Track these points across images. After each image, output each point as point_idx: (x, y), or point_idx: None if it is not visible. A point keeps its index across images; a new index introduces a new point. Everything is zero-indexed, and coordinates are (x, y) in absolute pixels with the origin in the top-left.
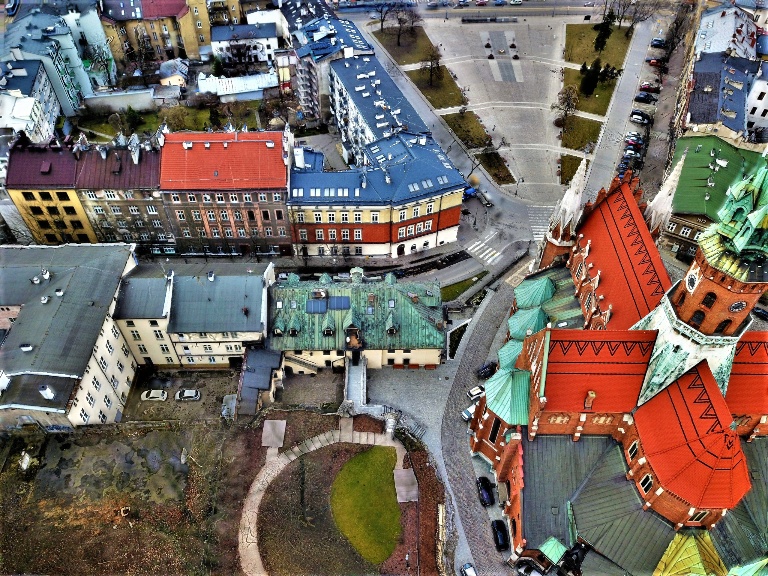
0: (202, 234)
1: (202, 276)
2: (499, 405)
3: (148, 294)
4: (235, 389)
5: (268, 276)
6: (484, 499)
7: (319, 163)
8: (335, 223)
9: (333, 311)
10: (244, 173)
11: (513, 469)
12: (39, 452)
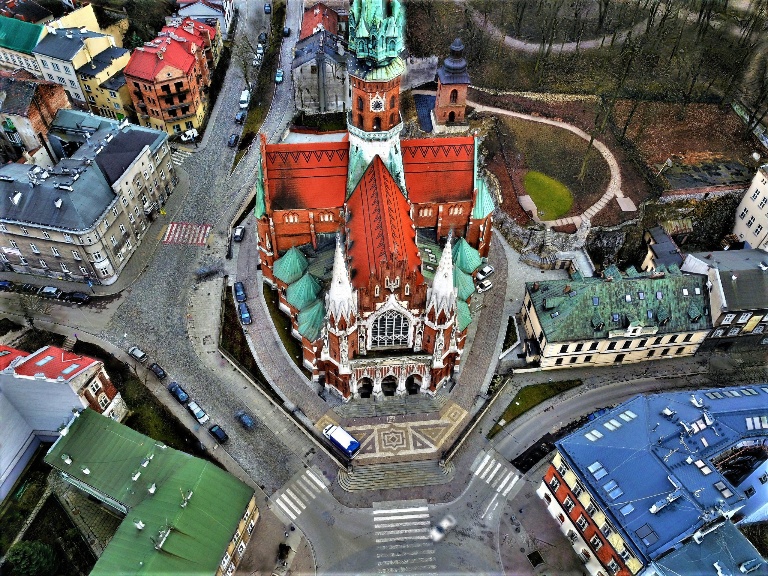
0: None
1: None
2: None
3: None
4: None
5: None
6: None
7: None
8: None
9: None
10: None
11: None
12: None
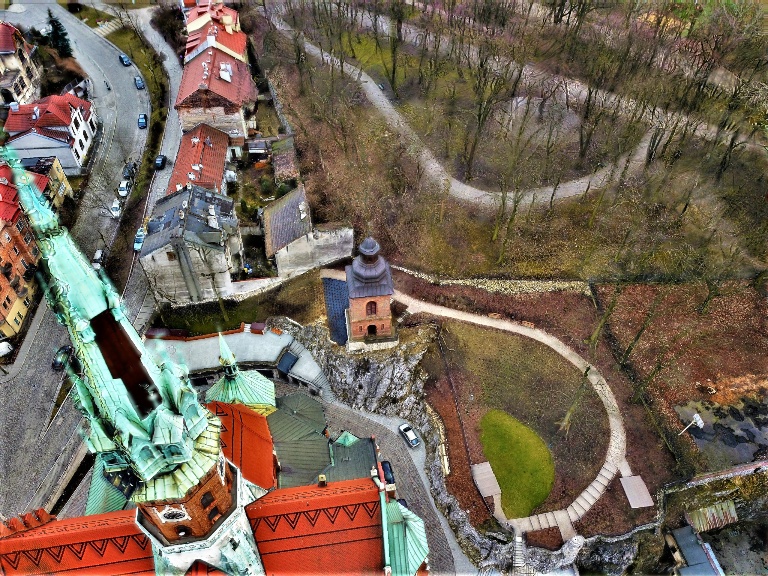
0: None
1: None
2: (411, 516)
3: None
4: None
5: None
6: (405, 501)
7: None
8: None
9: None
10: None
11: None
12: None
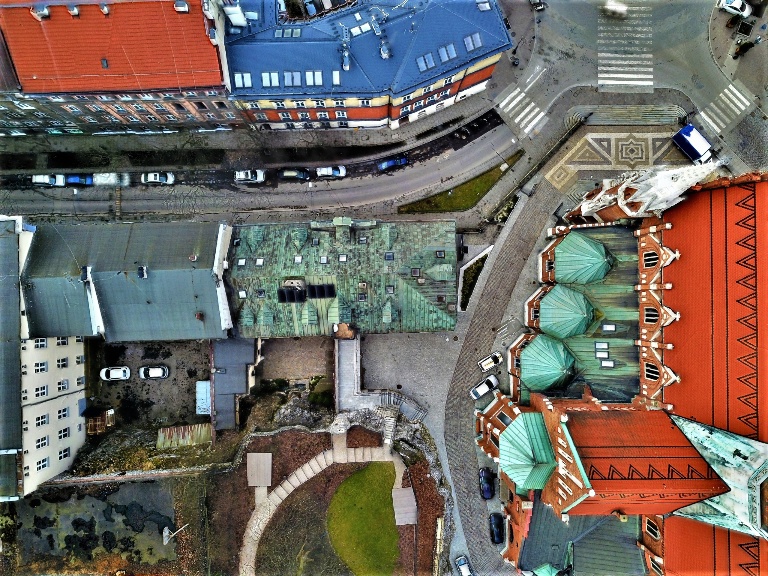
0: (113, 118)
1: (130, 271)
2: (513, 472)
3: (65, 302)
4: (207, 359)
5: (220, 258)
6: (484, 497)
7: (270, 4)
8: (306, 108)
9: (314, 299)
10: (150, 62)
11: (519, 503)
12: (9, 510)
